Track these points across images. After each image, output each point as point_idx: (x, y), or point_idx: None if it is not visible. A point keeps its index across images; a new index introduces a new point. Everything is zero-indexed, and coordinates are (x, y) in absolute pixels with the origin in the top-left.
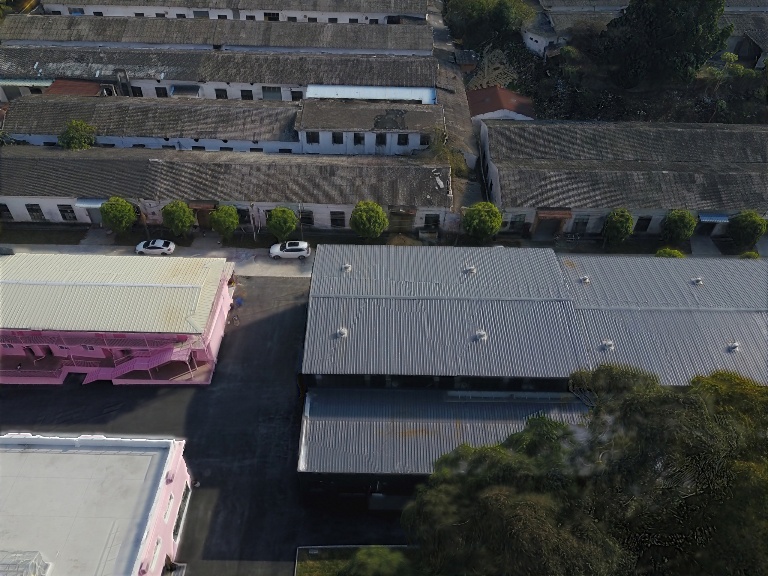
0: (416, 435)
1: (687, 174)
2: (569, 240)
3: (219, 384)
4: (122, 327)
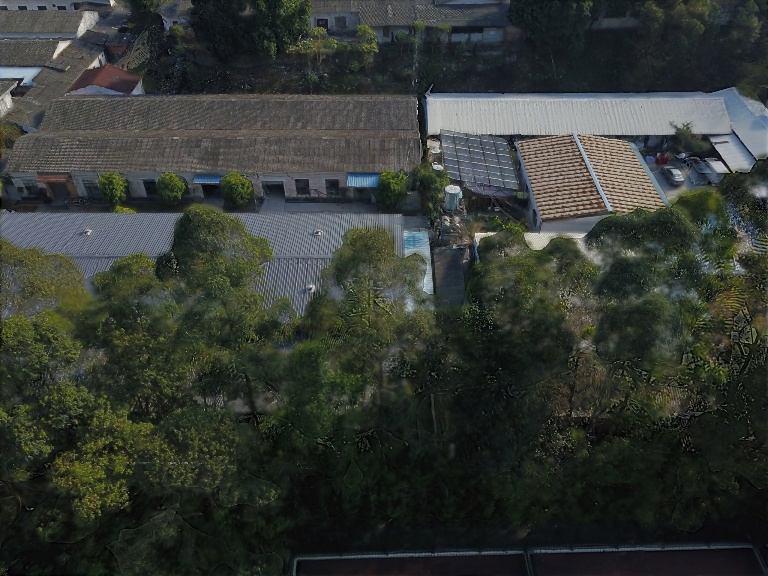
0: None
1: (195, 139)
2: (76, 203)
3: None
4: None
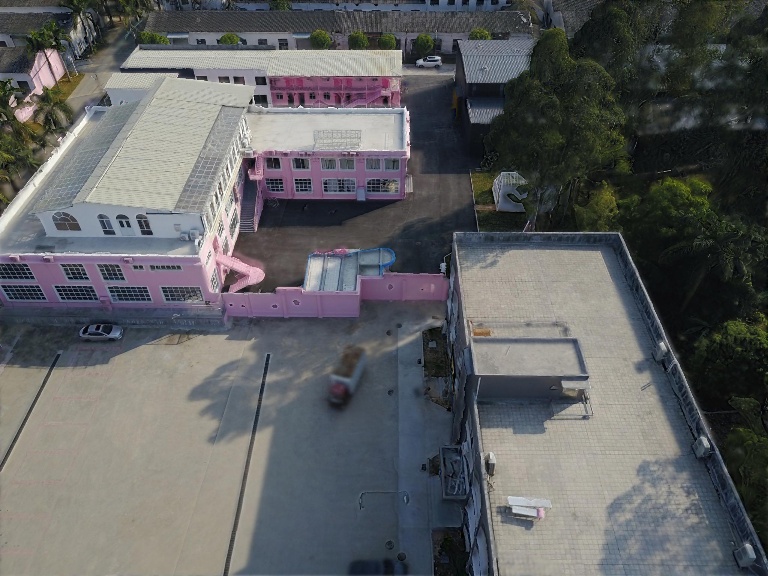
0: None
1: None
2: None
3: None
4: (355, 74)
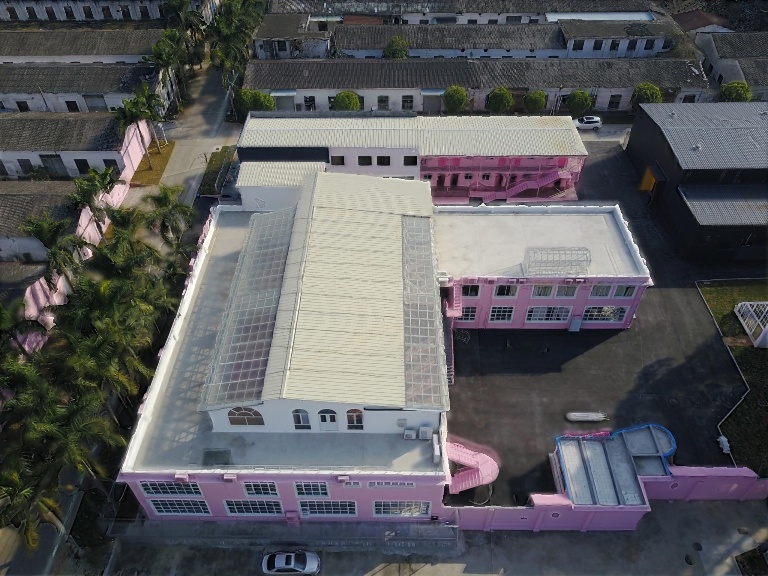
0: (767, 208)
1: None
2: None
3: (584, 200)
4: (530, 153)
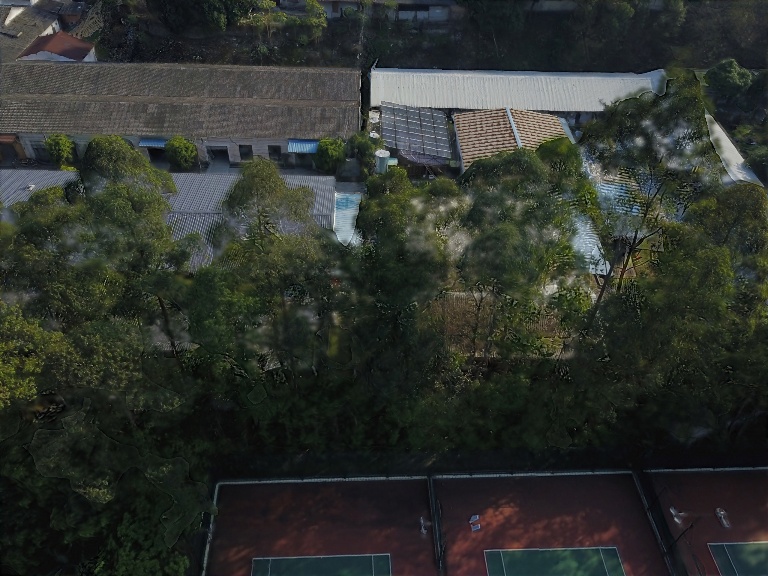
0: None
1: (142, 104)
2: (23, 164)
3: None
4: None
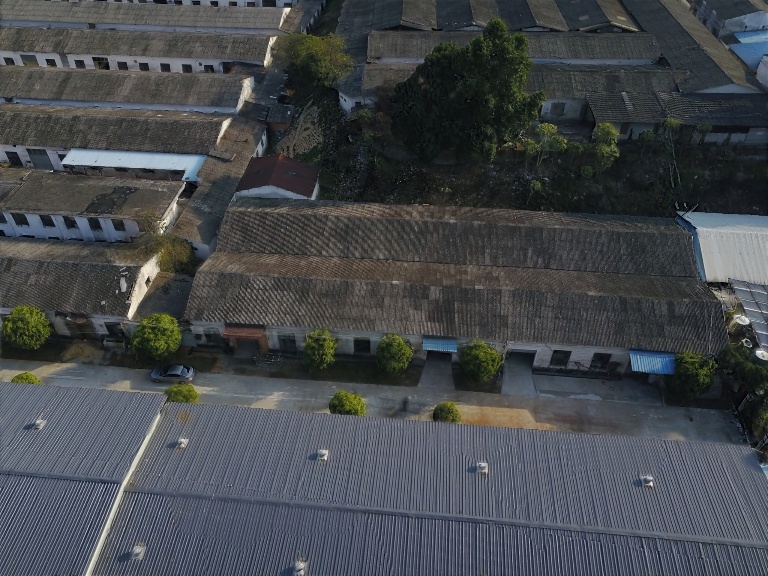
0: None
1: (421, 286)
2: (268, 361)
3: None
4: None
